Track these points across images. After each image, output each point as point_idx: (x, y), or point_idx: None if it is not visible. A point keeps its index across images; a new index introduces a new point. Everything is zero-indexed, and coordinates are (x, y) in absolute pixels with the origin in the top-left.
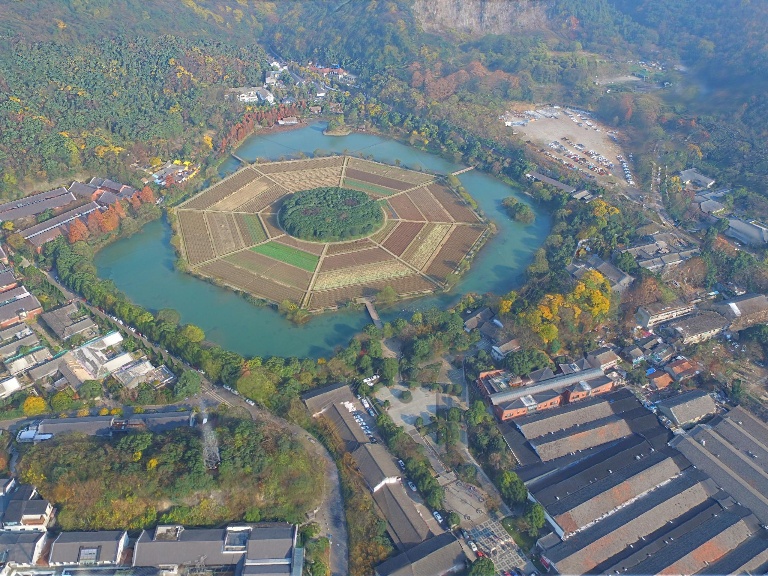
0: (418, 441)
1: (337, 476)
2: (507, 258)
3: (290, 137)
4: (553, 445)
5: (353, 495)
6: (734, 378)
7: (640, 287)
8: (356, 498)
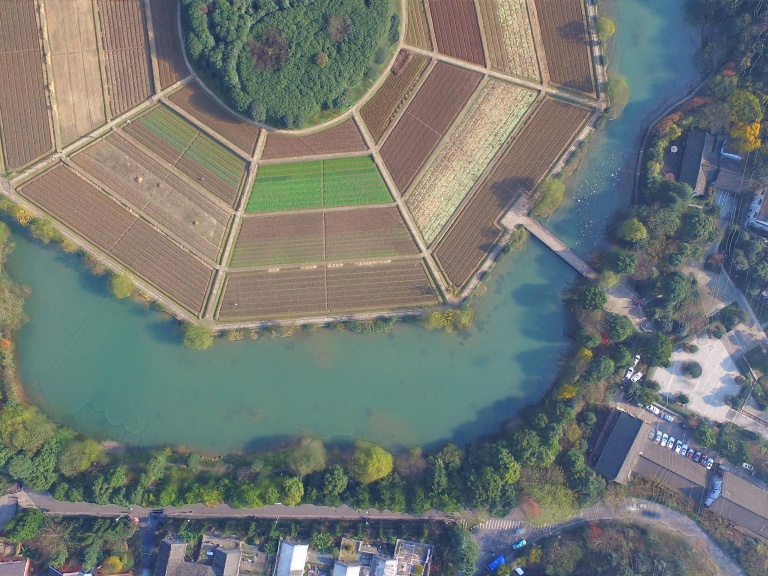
0: (743, 424)
1: (700, 530)
2: None
3: None
4: None
5: (737, 547)
6: None
7: None
8: (753, 558)
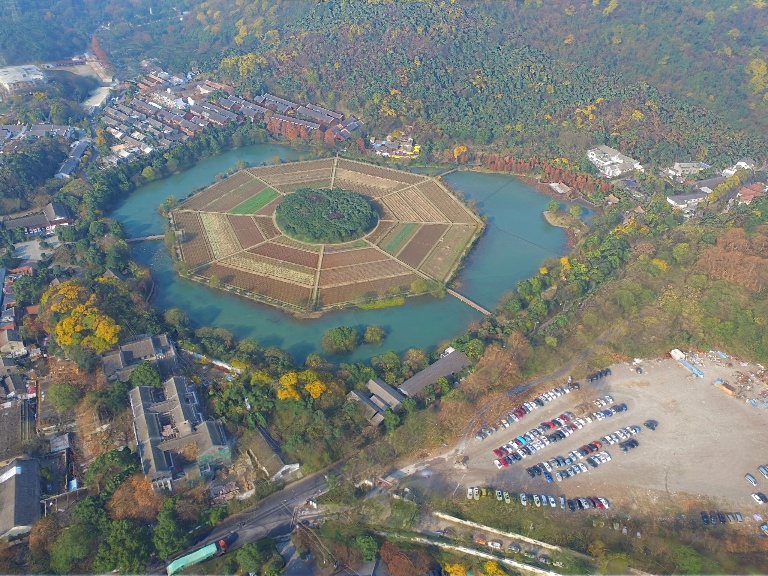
0: None
1: None
2: (238, 320)
3: (523, 194)
4: None
5: None
6: None
7: None
8: None
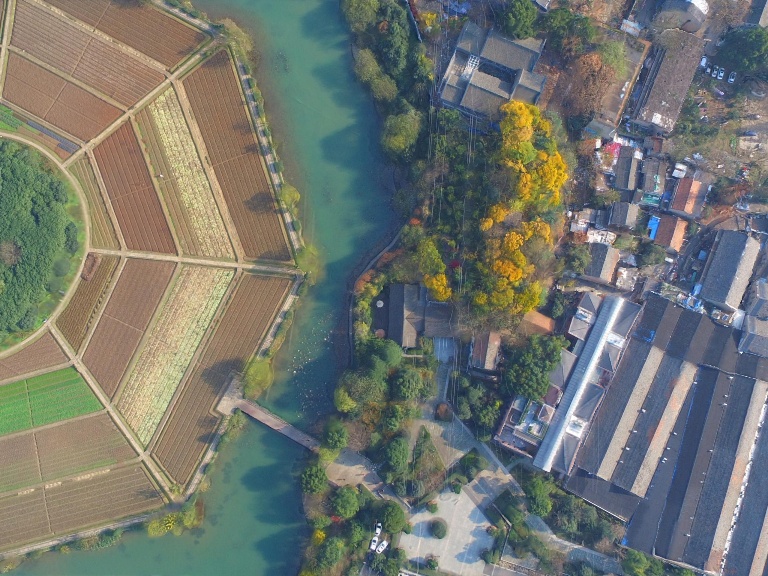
0: None
1: None
2: (319, 106)
3: None
4: (643, 471)
5: None
6: (744, 151)
7: (559, 52)
8: None
